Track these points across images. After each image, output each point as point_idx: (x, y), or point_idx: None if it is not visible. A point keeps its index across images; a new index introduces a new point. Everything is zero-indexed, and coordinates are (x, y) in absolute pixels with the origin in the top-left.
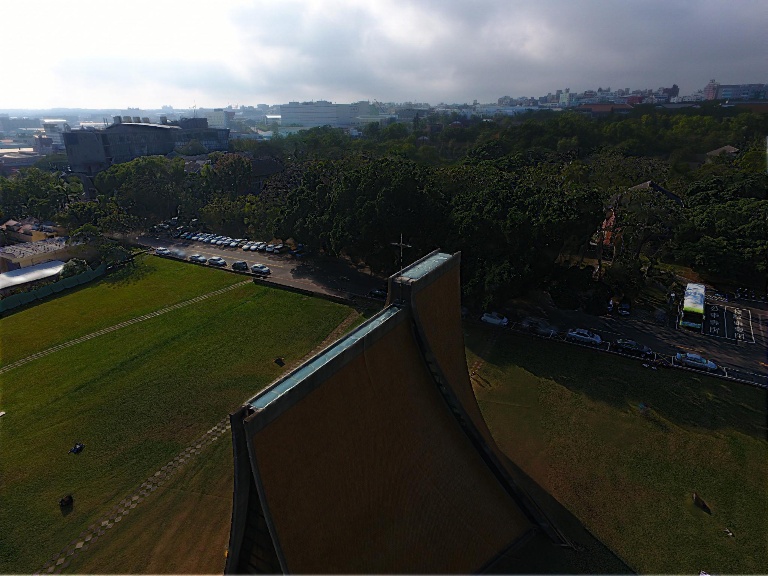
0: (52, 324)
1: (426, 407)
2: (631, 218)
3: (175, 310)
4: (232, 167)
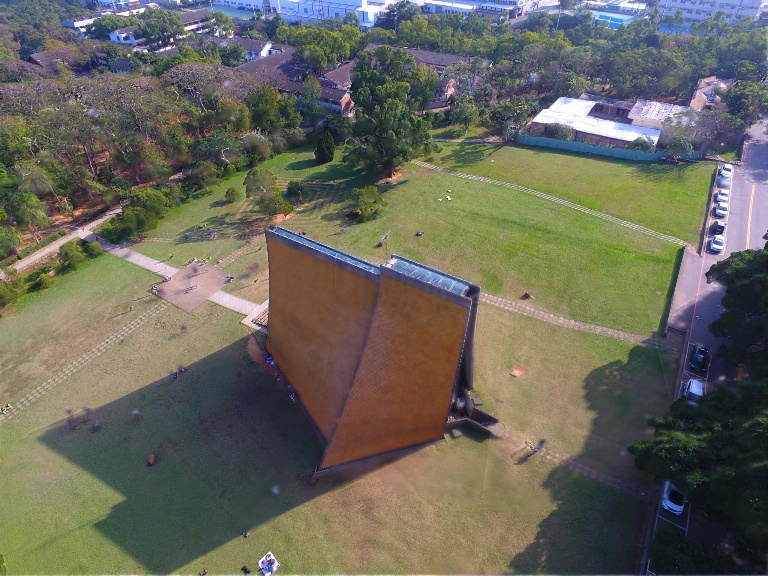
0: (554, 174)
1: (359, 337)
2: None
3: (597, 218)
4: None
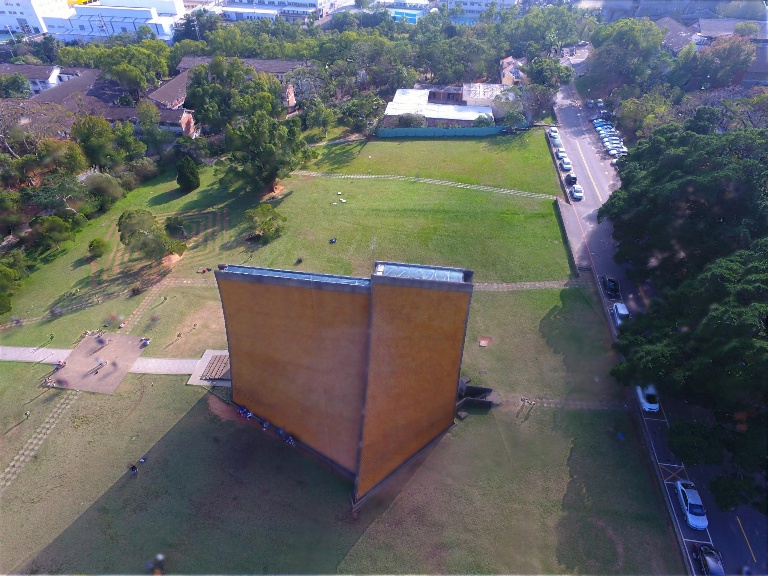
0: (425, 159)
1: (354, 354)
2: None
3: (479, 191)
4: (723, 54)
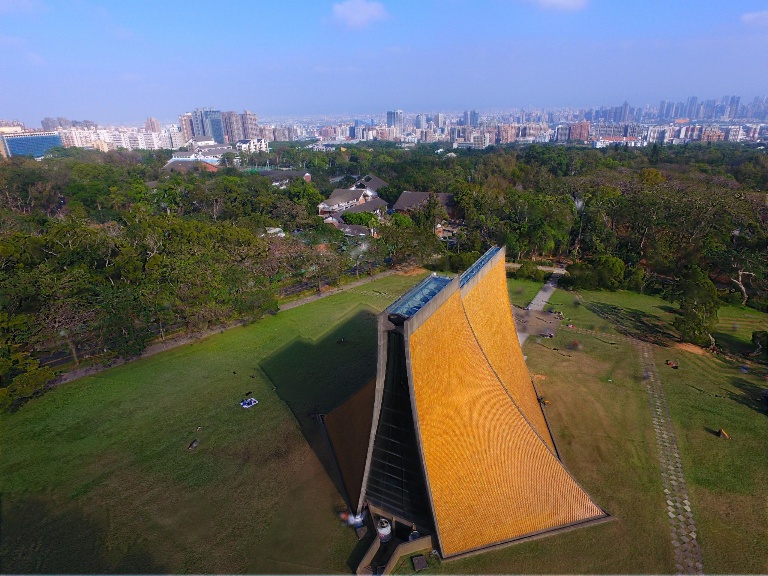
0: None
1: None
2: None
3: None
4: None
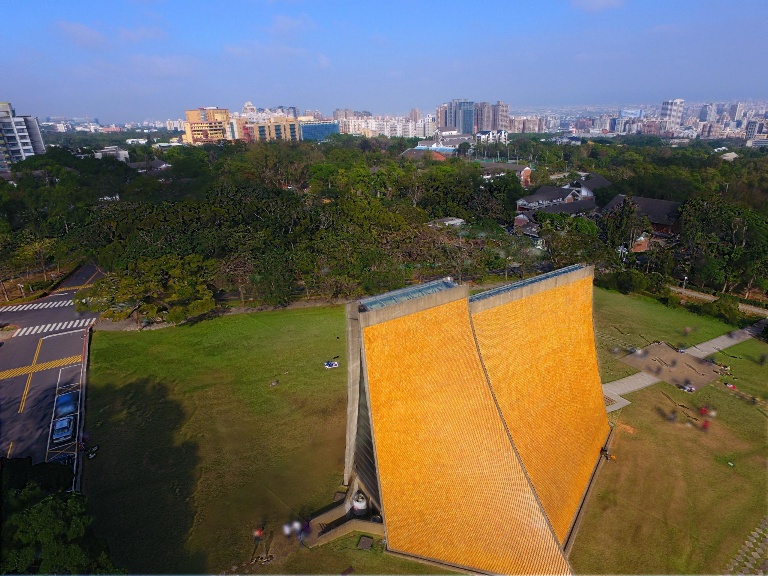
0: None
1: None
2: None
3: None
4: None
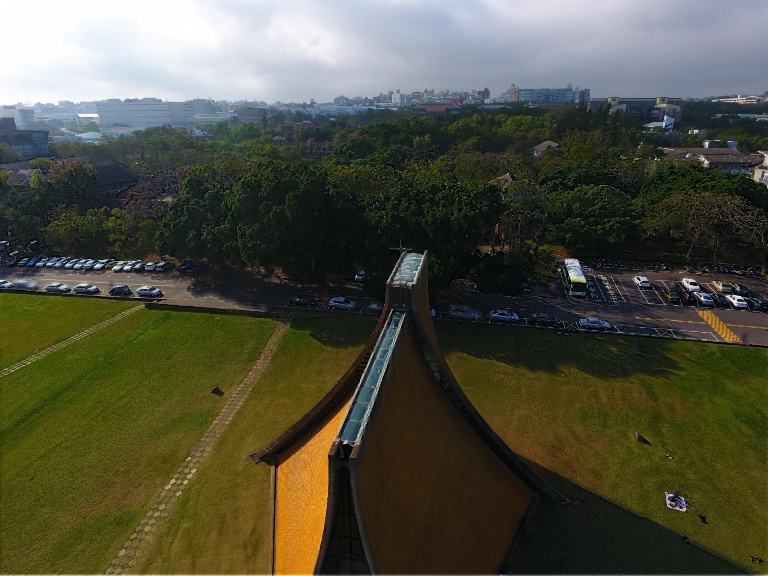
0: None
1: (436, 406)
2: (518, 207)
3: (52, 354)
4: (72, 176)
